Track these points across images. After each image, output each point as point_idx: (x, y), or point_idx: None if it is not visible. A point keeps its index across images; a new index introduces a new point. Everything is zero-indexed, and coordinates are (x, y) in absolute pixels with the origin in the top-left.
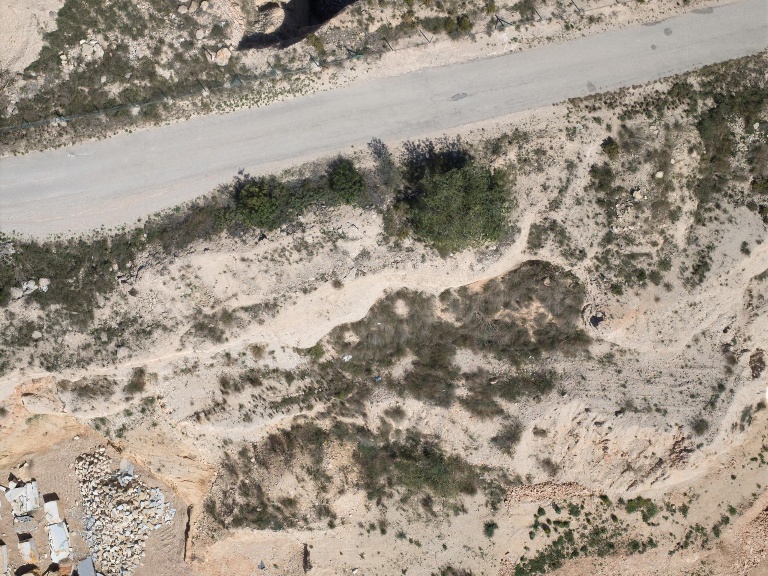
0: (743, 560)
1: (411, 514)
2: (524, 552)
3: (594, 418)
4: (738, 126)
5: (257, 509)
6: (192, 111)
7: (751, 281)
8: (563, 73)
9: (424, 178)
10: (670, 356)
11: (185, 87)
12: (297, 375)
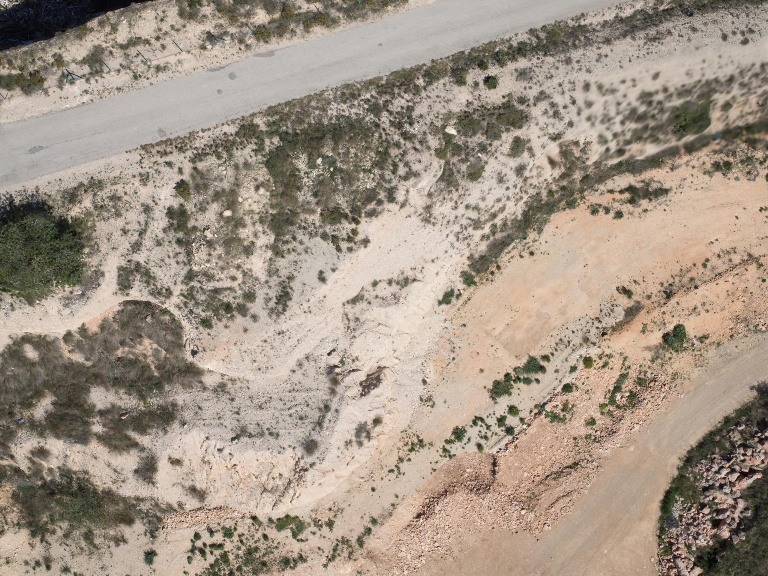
0: (402, 566)
1: (74, 548)
2: None
3: (215, 445)
4: (301, 162)
5: None
6: None
7: (344, 305)
8: (134, 121)
9: None
10: (277, 382)
11: None
12: None
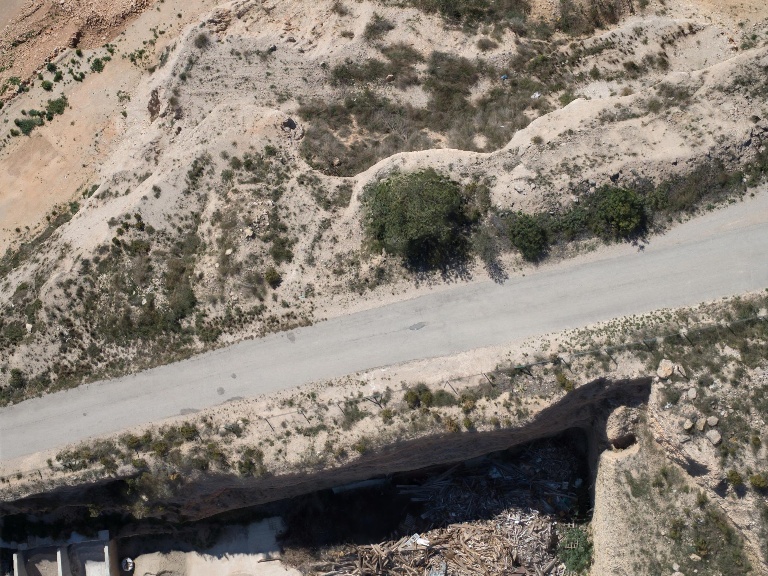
0: None
1: None
2: None
3: (296, 45)
4: (160, 300)
5: None
6: (698, 312)
7: None
8: (317, 351)
9: None
10: None
11: (707, 338)
12: (587, 77)
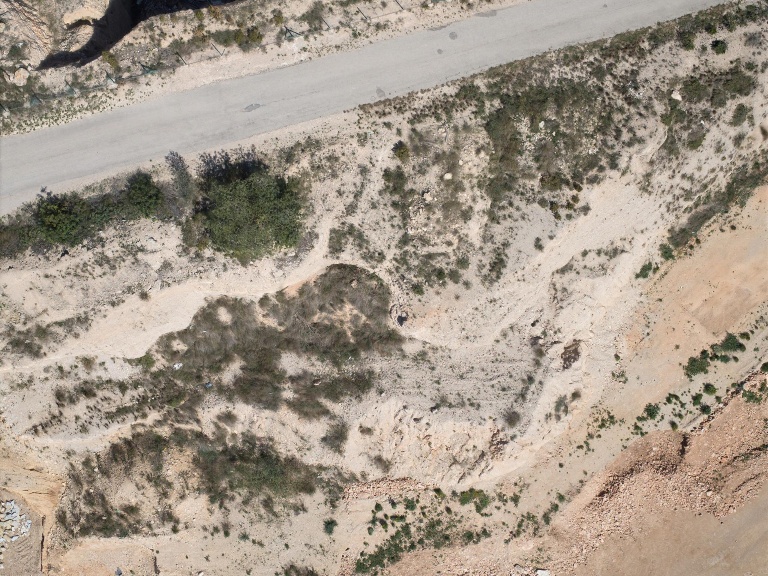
0: (581, 545)
1: (253, 515)
2: (364, 547)
3: (412, 415)
4: (523, 125)
5: (102, 517)
6: None
7: (553, 275)
8: (353, 80)
9: (211, 190)
10: (480, 351)
11: None
12: (130, 385)
